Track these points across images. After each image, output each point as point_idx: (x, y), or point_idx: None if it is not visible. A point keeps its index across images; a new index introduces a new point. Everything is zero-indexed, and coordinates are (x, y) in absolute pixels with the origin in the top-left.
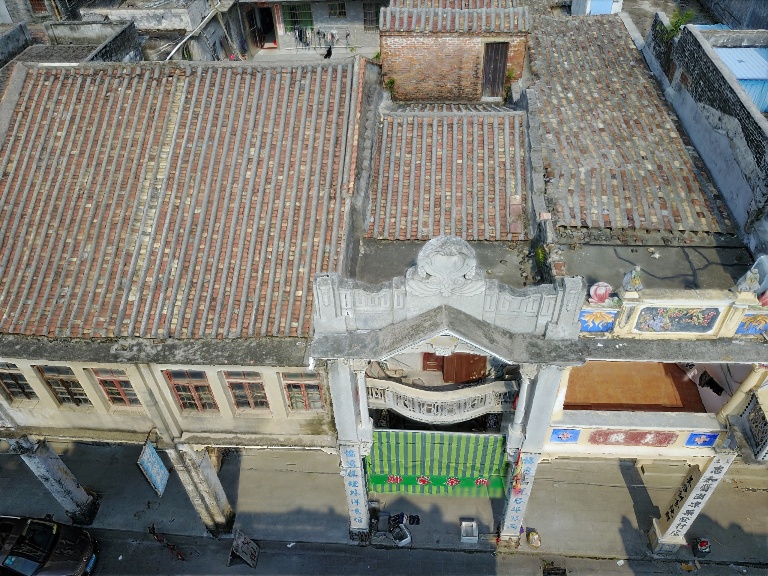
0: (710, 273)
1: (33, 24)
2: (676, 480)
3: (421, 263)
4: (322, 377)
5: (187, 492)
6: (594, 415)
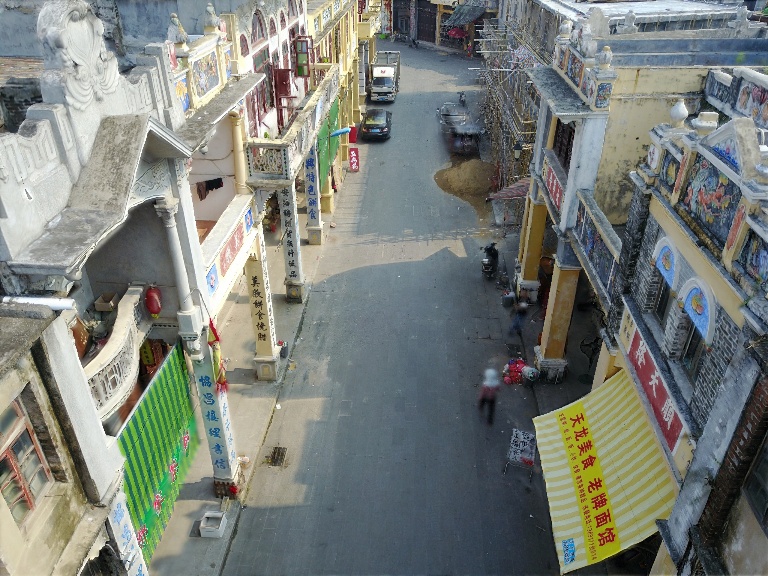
0: None
1: None
2: None
3: (64, 41)
4: (35, 388)
5: None
6: (209, 242)
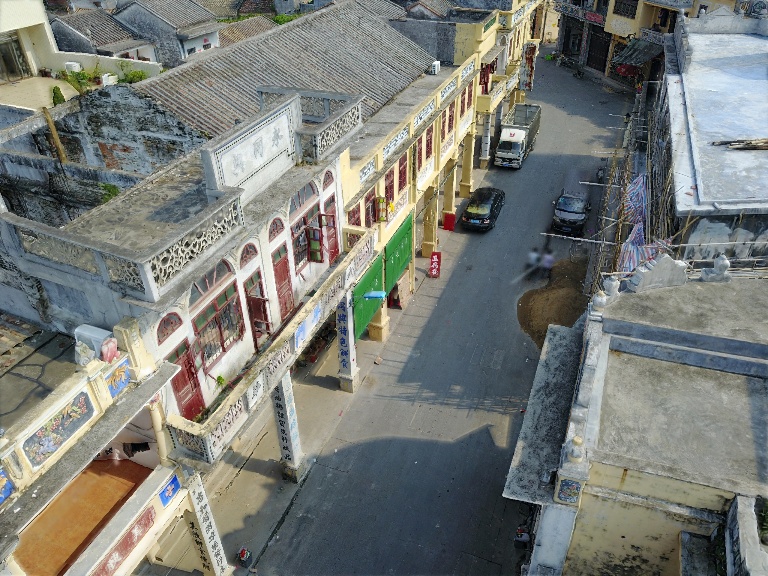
0: (51, 373)
1: None
2: (186, 537)
3: None
4: None
5: None
6: (76, 568)
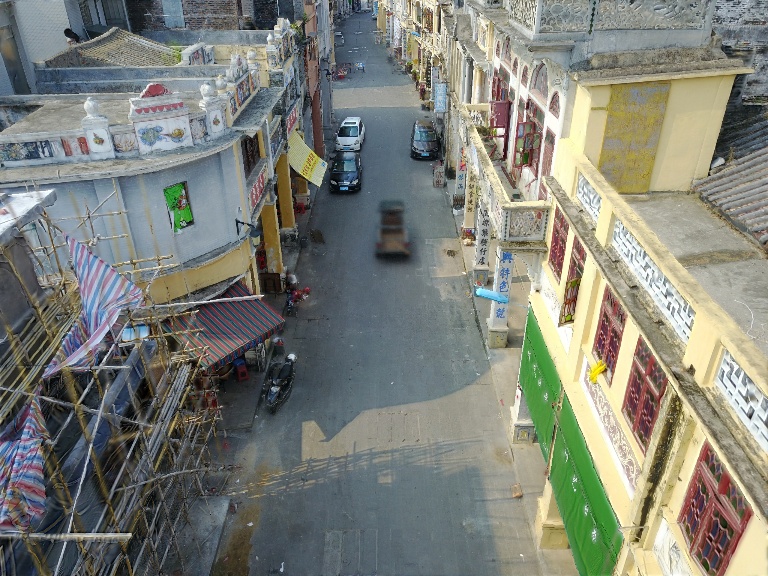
0: None
1: None
2: None
3: None
4: None
5: None
6: None
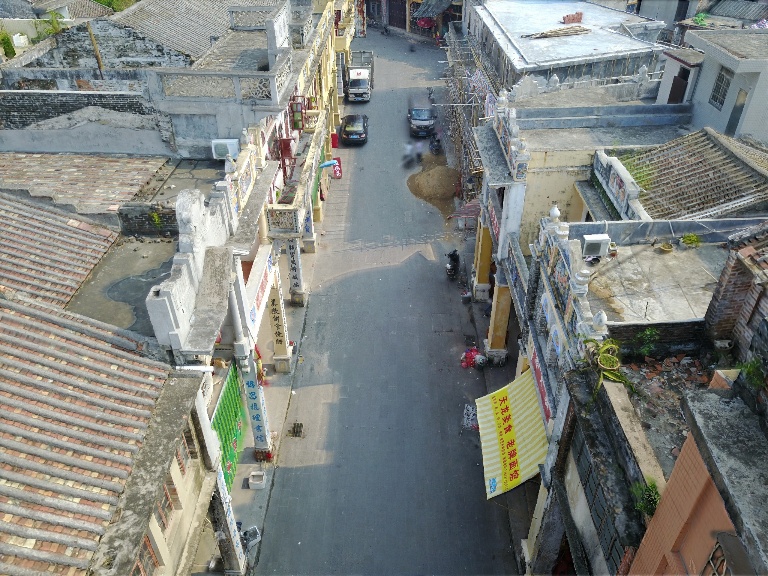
0: (199, 174)
1: None
2: None
3: (191, 219)
4: None
5: None
6: (249, 289)
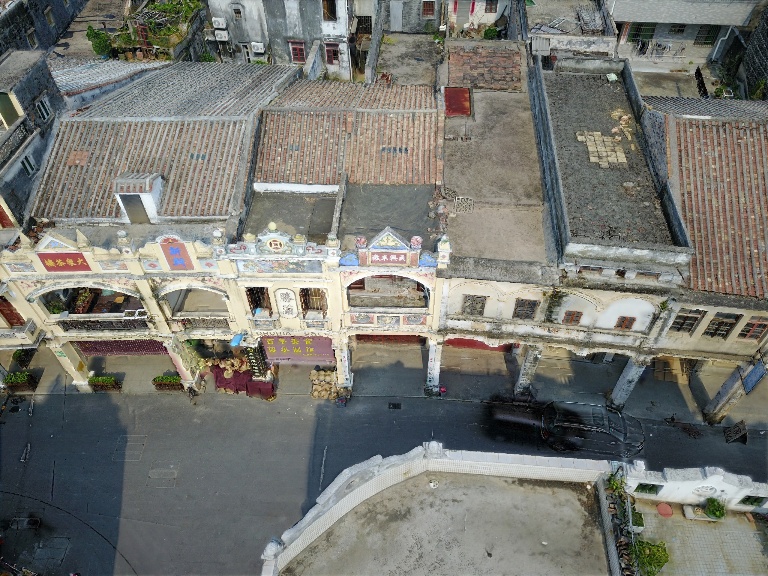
0: None
1: (481, 40)
2: None
3: None
4: None
5: (727, 394)
6: None
